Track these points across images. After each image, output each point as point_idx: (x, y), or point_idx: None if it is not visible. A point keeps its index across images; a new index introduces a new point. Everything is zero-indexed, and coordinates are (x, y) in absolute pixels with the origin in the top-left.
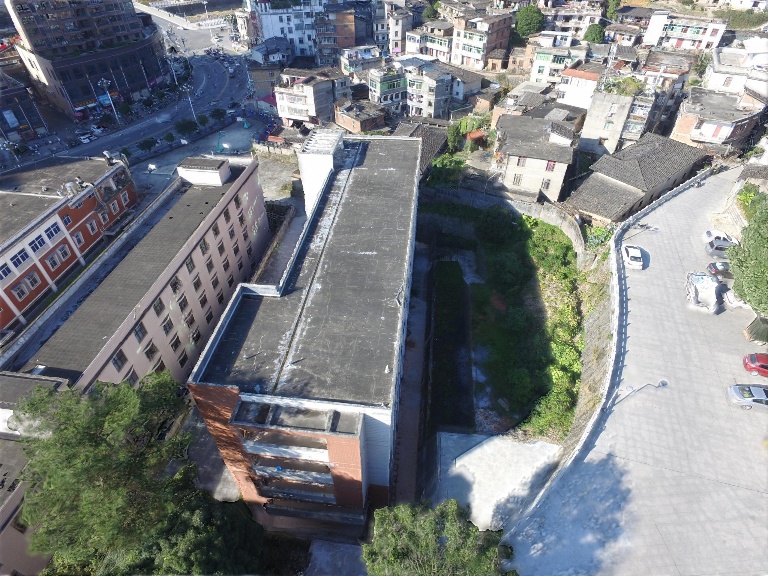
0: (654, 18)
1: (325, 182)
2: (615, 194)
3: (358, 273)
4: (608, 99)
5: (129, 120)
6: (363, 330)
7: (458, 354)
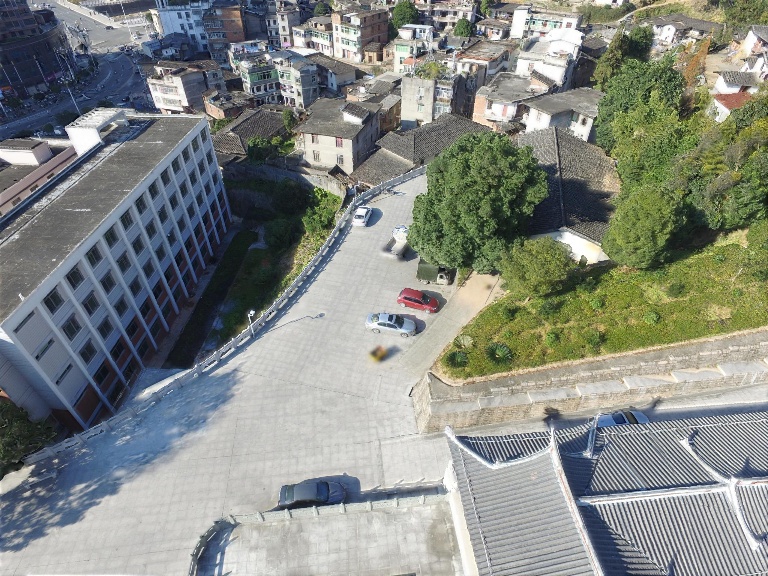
0: (517, 13)
1: (86, 153)
2: (392, 166)
3: (60, 226)
4: (415, 83)
5: (19, 113)
6: (29, 269)
7: (214, 309)
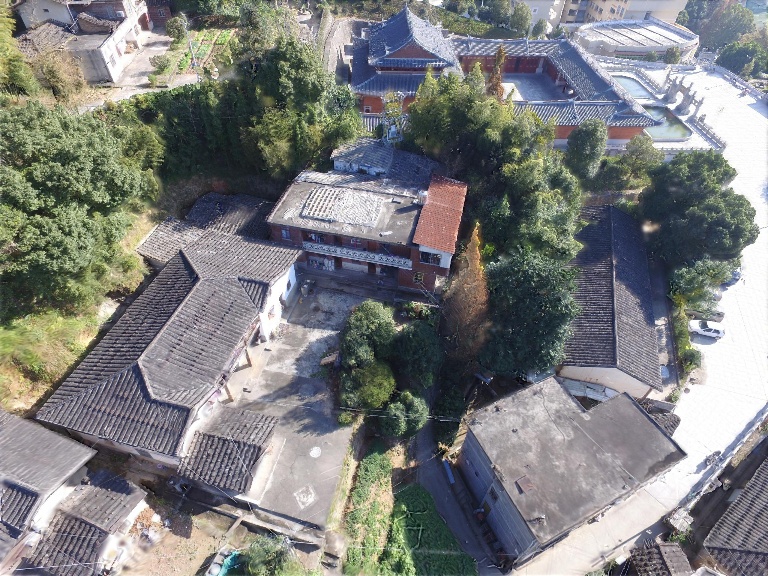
0: None
1: None
2: None
3: None
4: None
5: None
6: None
7: None
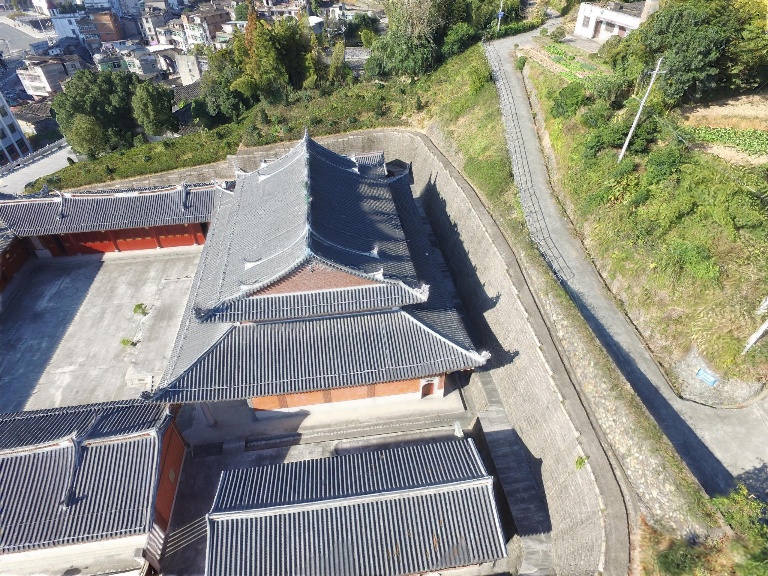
0: None
1: None
2: None
3: None
4: (183, 59)
5: None
6: None
7: None
